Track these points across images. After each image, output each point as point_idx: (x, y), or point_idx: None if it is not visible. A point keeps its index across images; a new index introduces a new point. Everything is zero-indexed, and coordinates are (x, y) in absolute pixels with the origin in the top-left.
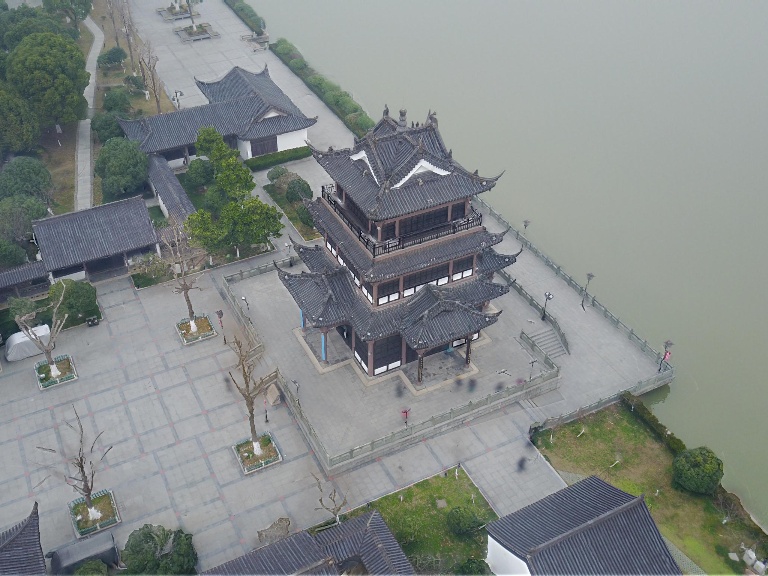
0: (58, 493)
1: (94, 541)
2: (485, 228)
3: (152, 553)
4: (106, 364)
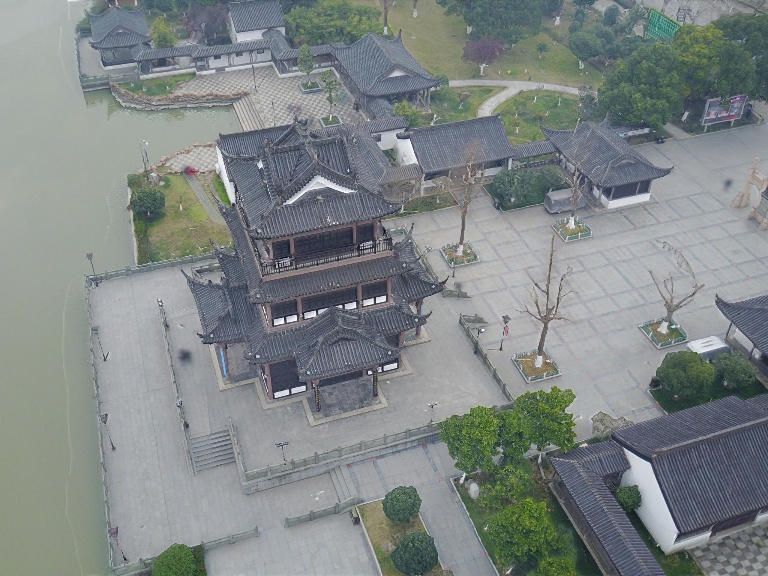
0: (606, 245)
1: (560, 194)
2: (234, 204)
3: (518, 171)
4: (618, 339)
